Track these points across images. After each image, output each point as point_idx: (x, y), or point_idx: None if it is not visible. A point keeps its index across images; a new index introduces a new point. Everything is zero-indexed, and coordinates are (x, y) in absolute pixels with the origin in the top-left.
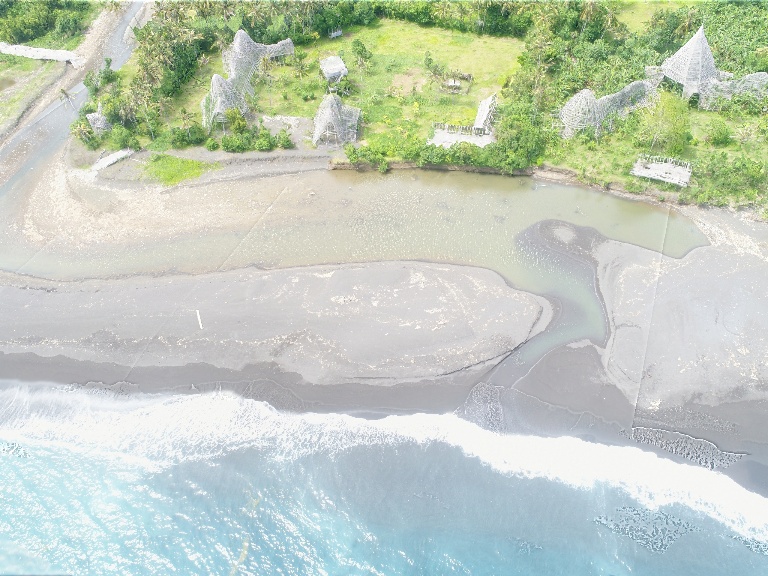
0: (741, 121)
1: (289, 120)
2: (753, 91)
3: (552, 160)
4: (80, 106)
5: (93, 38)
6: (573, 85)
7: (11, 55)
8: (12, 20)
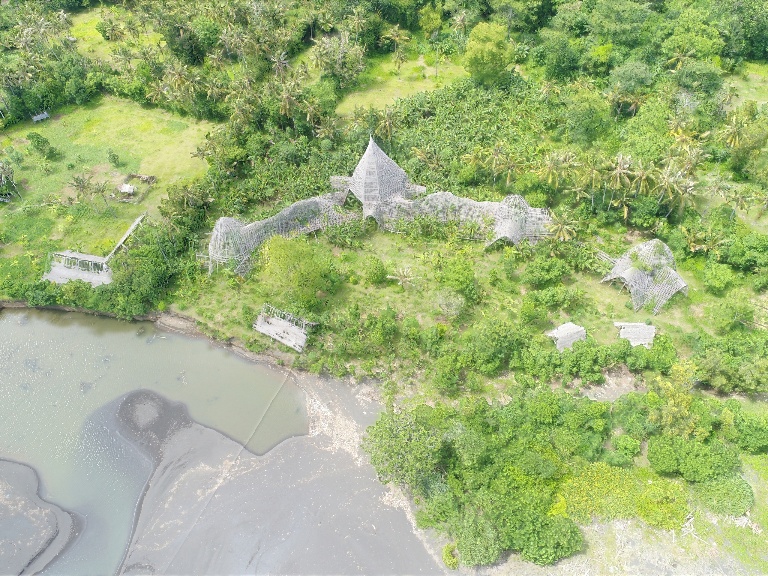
0: (424, 248)
1: None
2: (439, 212)
3: (182, 302)
4: None
5: None
6: (252, 196)
7: None
8: None
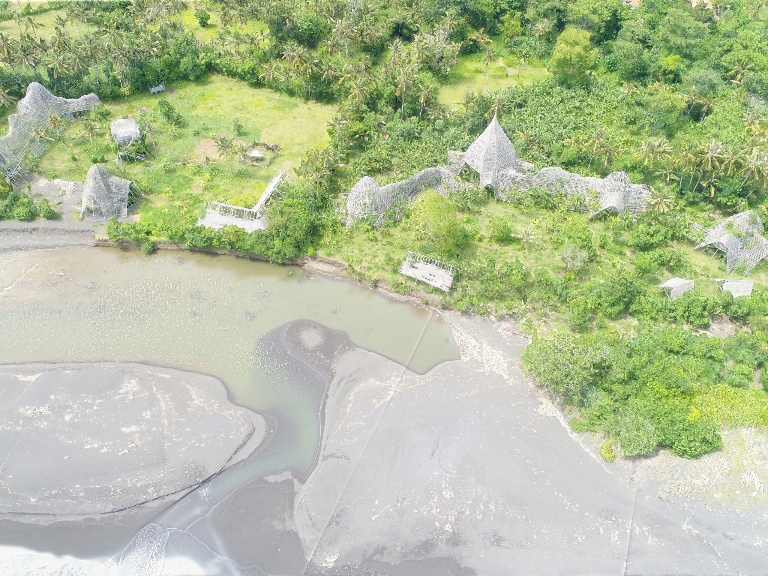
0: (535, 216)
1: (66, 186)
2: (549, 185)
3: None
4: None
5: None
6: (375, 165)
7: None
8: None
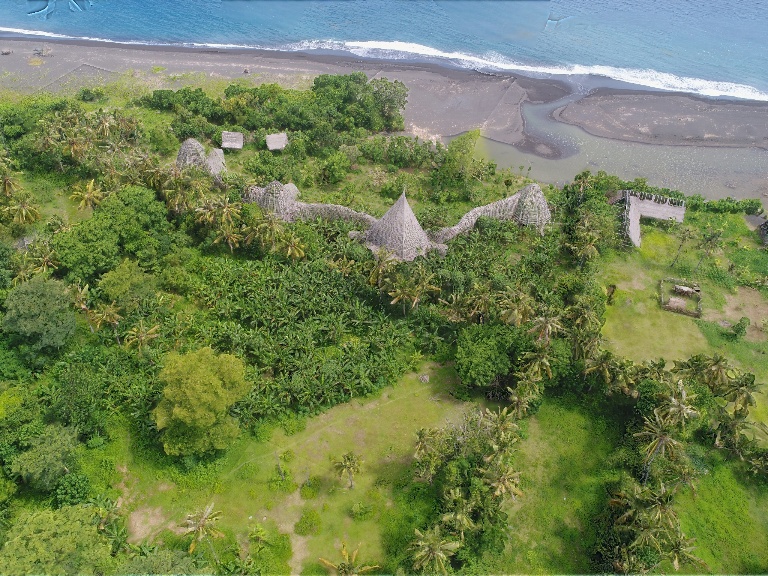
0: None
1: None
2: None
3: None
4: None
5: None
6: None
7: None
8: None
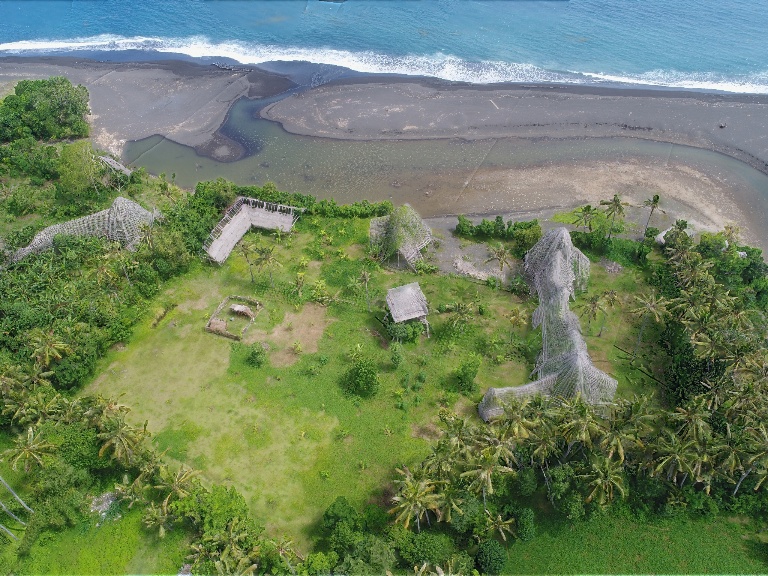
0: None
1: (467, 266)
2: None
3: None
4: None
5: None
6: None
7: None
8: None
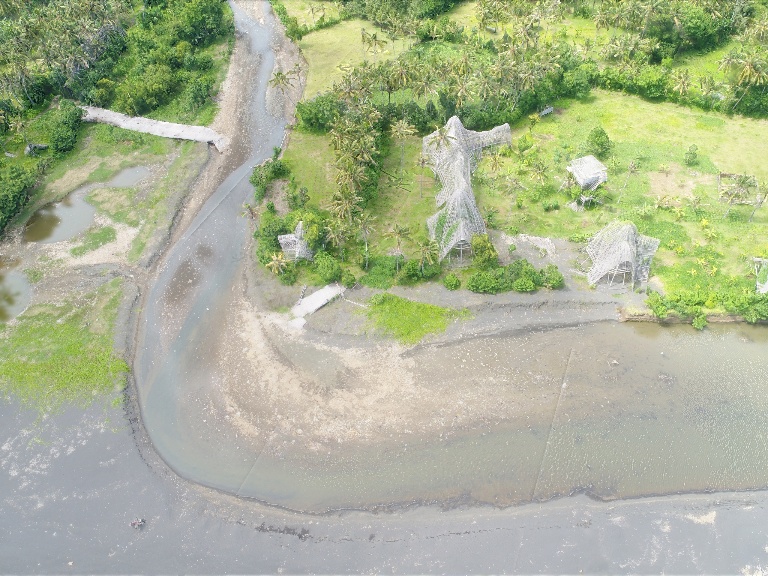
0: None
1: (541, 243)
2: None
3: None
4: (243, 209)
5: (229, 108)
6: None
7: (135, 132)
8: (131, 86)
